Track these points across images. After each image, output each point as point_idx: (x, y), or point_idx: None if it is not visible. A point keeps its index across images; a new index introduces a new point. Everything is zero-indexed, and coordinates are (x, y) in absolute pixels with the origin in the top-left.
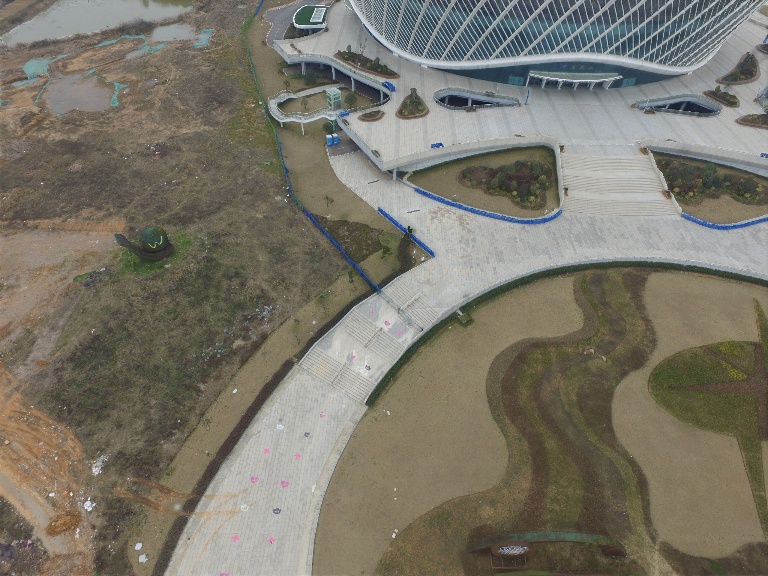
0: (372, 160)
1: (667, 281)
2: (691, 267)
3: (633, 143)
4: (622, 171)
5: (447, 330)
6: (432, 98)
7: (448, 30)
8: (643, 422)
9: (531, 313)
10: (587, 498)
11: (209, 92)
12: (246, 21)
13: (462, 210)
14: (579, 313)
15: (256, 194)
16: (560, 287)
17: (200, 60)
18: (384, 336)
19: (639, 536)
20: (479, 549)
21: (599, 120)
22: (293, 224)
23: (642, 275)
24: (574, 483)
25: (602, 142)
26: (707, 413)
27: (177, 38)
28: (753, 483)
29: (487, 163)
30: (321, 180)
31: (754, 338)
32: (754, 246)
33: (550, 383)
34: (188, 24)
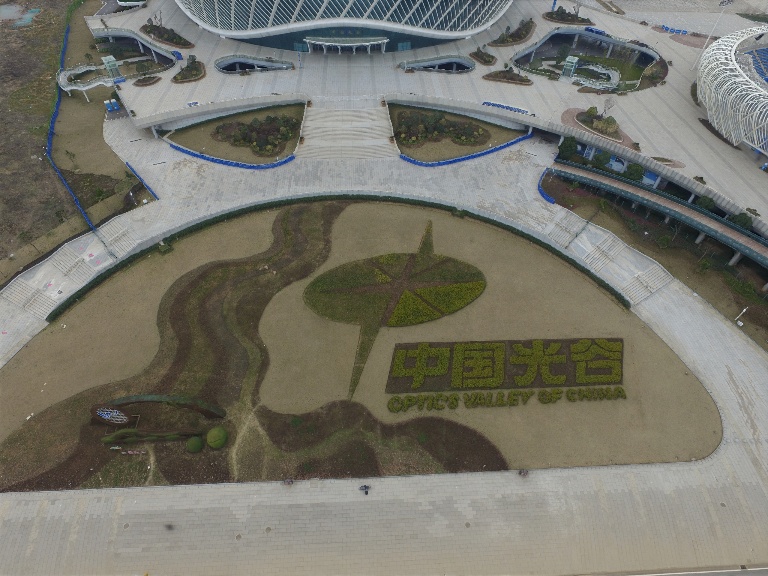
0: (132, 120)
1: (361, 210)
2: (385, 197)
3: (379, 97)
4: (359, 121)
5: (146, 258)
6: None
7: None
8: (286, 319)
9: (228, 241)
10: (211, 378)
11: (9, 66)
12: (76, 0)
13: (205, 160)
14: (270, 238)
15: (12, 154)
16: (264, 219)
17: (14, 38)
18: (84, 266)
19: (243, 403)
20: (92, 420)
21: (360, 79)
22: (38, 178)
23: (341, 206)
24: (205, 368)
25: (350, 97)
26: (344, 309)
27: (0, 18)
28: (358, 358)
29: (244, 120)
30: (85, 140)
31: (413, 250)
32: (450, 178)
33: (219, 294)
34: (18, 4)
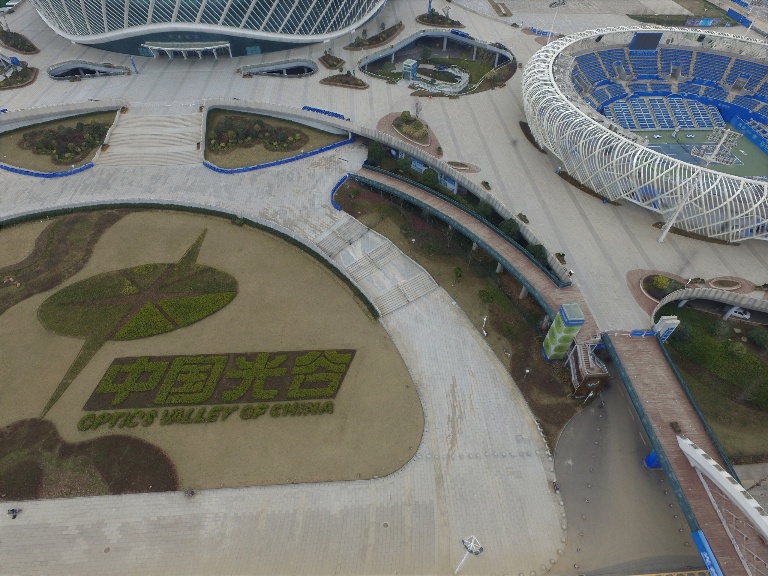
0: None
1: (139, 219)
2: (167, 205)
3: (201, 103)
4: (171, 127)
5: None
6: (49, 71)
7: (57, 5)
8: (10, 333)
9: None
10: None
11: None
12: None
13: (0, 169)
14: (30, 249)
15: None
16: (33, 229)
17: None
18: None
19: None
20: None
21: (192, 84)
22: None
23: (120, 215)
24: None
25: None
26: (76, 322)
27: None
28: (68, 374)
29: None
30: None
31: (175, 260)
32: (244, 185)
33: None
34: None
